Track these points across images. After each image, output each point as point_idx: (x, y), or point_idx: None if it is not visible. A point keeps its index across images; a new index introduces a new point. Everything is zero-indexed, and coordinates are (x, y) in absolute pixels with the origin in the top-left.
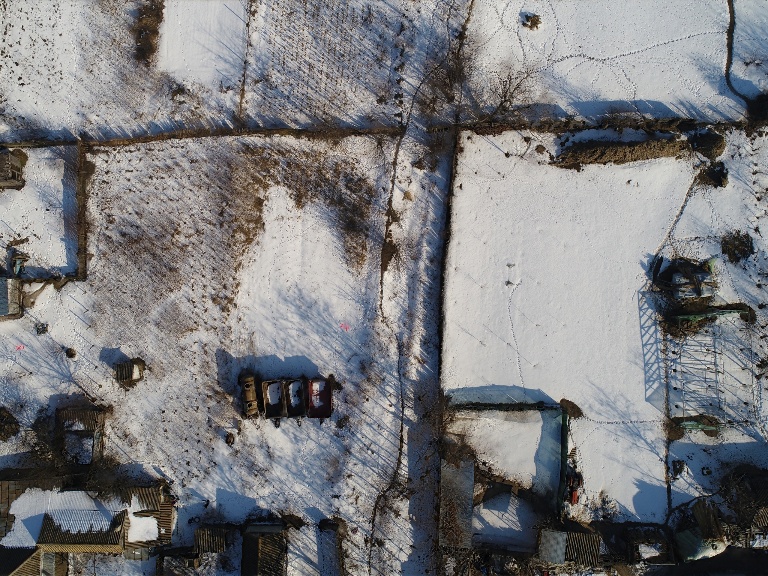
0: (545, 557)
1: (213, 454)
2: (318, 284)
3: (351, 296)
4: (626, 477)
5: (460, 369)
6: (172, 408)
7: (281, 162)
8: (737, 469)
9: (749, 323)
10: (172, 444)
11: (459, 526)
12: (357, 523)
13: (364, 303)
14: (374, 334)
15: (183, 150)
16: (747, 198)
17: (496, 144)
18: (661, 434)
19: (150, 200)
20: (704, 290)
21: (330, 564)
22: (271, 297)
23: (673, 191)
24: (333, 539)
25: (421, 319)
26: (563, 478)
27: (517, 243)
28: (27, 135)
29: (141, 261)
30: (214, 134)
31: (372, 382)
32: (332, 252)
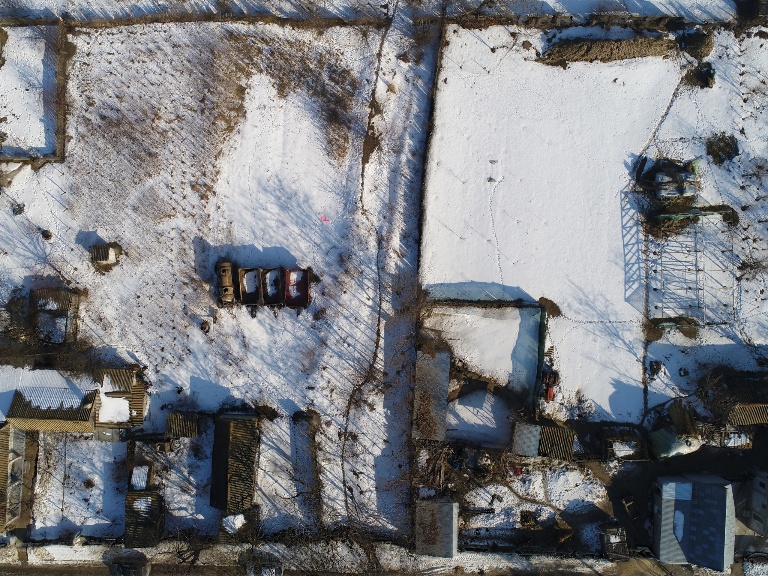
0: (518, 450)
1: (188, 341)
2: (299, 175)
3: (332, 188)
4: (603, 377)
5: (439, 264)
6: (148, 293)
7: (264, 50)
8: (714, 370)
9: (731, 225)
10: (147, 329)
11: (433, 418)
12: (331, 416)
13: (344, 195)
14: (353, 226)
15: (166, 34)
16: (733, 99)
17: (482, 38)
18: (639, 335)
19: (131, 84)
20: (687, 189)
21: (303, 457)
22: (251, 186)
23: (659, 91)
24: (307, 431)
25: (401, 213)
26: (539, 374)
27: (500, 139)
28: (8, 13)
29: (120, 145)
30: (197, 19)
31: (350, 275)
32: (314, 143)
